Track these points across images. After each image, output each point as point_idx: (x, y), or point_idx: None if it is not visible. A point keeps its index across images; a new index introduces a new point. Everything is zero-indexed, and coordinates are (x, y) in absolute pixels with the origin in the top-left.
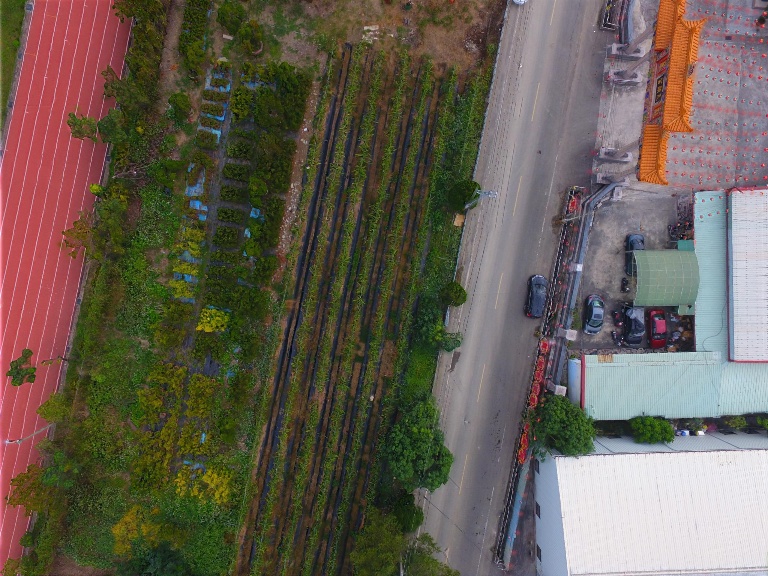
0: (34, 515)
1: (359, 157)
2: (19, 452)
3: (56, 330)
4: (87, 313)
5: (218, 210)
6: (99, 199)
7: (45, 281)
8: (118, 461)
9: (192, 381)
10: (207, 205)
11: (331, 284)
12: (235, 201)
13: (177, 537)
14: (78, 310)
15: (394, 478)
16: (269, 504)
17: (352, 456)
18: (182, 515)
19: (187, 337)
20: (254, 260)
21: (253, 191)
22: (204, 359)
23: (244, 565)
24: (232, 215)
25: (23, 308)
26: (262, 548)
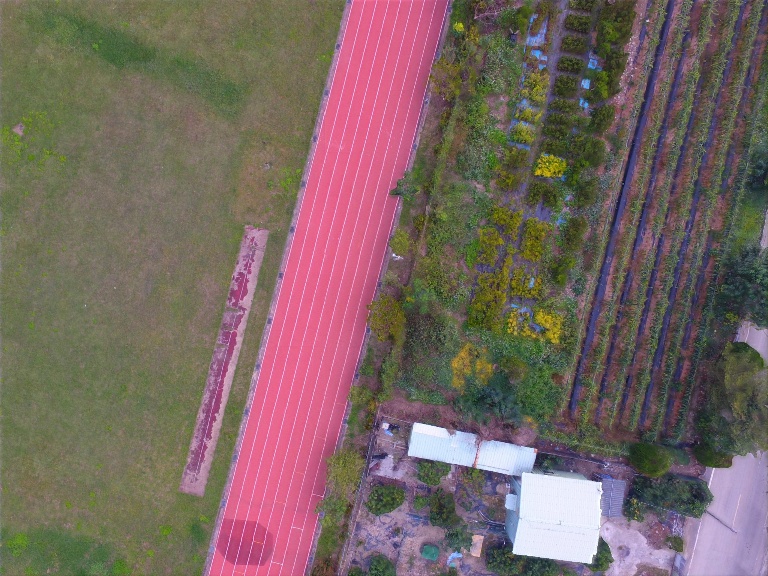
0: (363, 352)
1: (706, 8)
2: (353, 290)
3: (392, 174)
4: (424, 158)
5: (563, 57)
6: (438, 49)
7: (385, 126)
8: (452, 300)
9: (531, 223)
10: (547, 55)
11: (662, 137)
12: (576, 51)
13: (525, 367)
14: (414, 155)
15: (715, 331)
16: (603, 345)
17: (685, 303)
18: (513, 355)
19: (521, 183)
20: (590, 110)
21: (609, 35)
22: (536, 205)
23: (566, 409)
24: (577, 62)
25: (363, 151)
26: (594, 388)
